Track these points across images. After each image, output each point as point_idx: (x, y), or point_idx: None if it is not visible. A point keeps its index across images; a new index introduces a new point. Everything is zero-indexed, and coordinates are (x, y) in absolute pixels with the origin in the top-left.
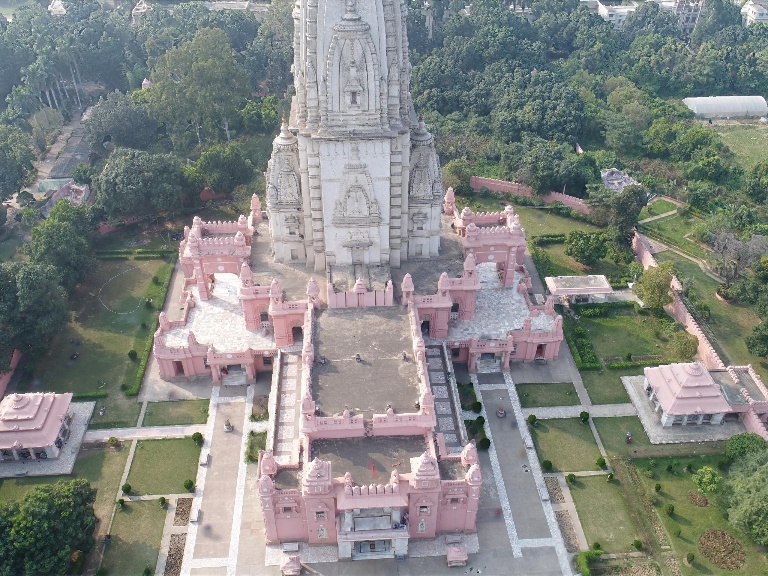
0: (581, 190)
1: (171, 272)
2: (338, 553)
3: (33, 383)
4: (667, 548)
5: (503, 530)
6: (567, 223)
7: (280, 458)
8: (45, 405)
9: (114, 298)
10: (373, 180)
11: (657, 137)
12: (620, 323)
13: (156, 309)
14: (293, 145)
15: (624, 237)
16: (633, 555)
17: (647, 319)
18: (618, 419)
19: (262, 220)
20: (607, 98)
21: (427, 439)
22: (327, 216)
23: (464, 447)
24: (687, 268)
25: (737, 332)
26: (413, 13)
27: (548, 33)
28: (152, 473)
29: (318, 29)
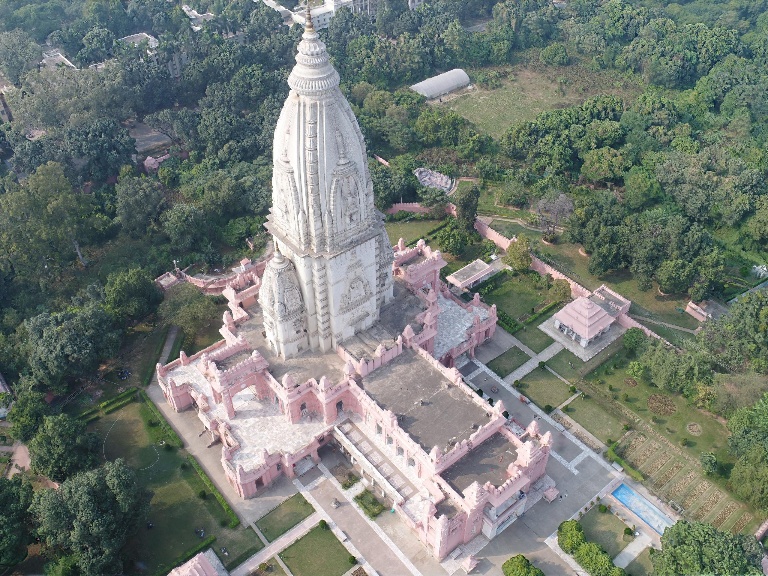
0: (412, 195)
1: (156, 409)
2: (487, 538)
3: (140, 567)
4: (639, 420)
5: (557, 463)
6: (416, 225)
7: (411, 501)
8: (201, 573)
9: (127, 458)
10: (365, 269)
11: (427, 130)
12: (508, 289)
13: (177, 447)
14: (289, 265)
15: (471, 224)
16: (628, 435)
17: (520, 278)
18: (557, 356)
19: (236, 329)
20: (365, 105)
21: (503, 433)
22: (336, 309)
23: (529, 425)
24: (514, 229)
25: (572, 263)
26: (159, 71)
27: (278, 56)
28: (314, 570)
29: (320, 178)
